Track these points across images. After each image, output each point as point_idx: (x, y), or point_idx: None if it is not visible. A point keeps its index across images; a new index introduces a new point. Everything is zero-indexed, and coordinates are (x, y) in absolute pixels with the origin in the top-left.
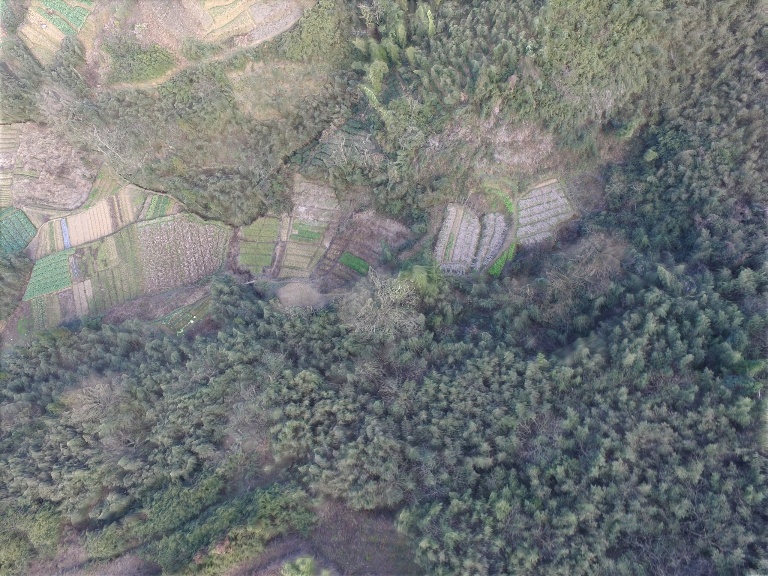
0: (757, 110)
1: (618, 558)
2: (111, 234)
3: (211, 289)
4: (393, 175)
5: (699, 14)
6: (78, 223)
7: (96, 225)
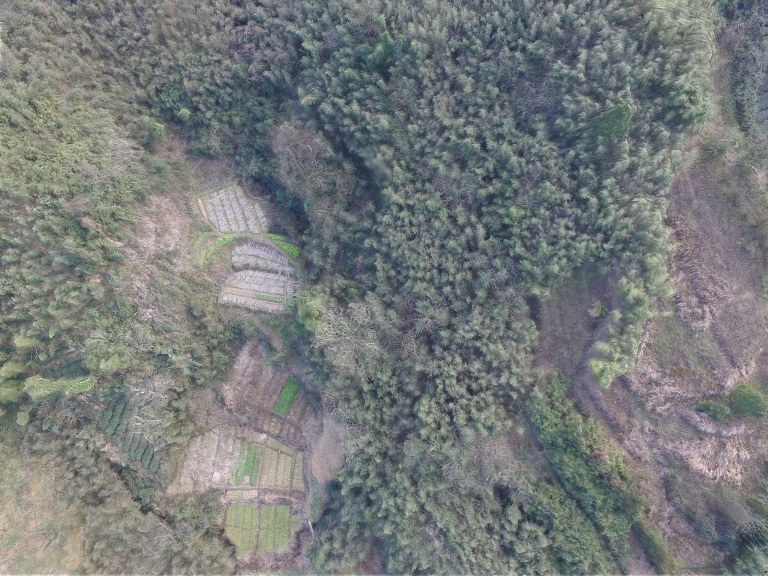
0: (152, 27)
1: (535, 129)
2: None
3: (327, 569)
4: (183, 361)
5: (39, 55)
6: None
7: None
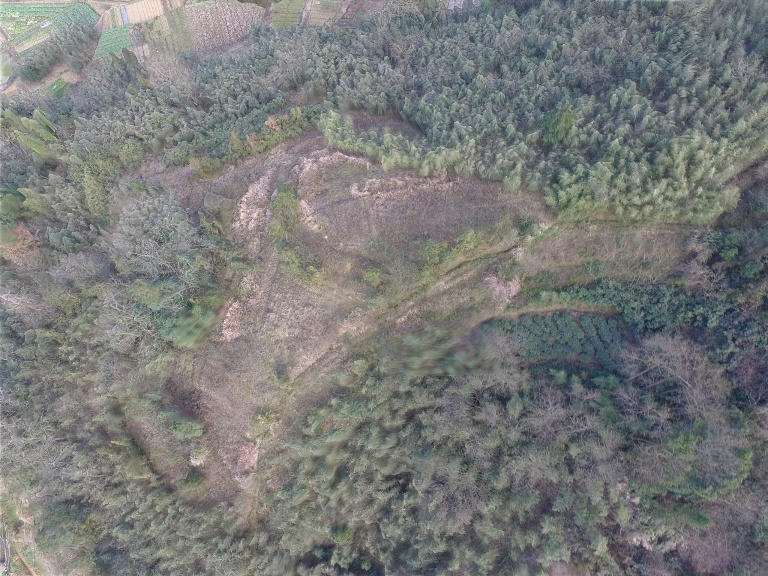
0: None
1: None
2: (163, 14)
3: (251, 27)
4: None
5: None
6: (135, 9)
7: (150, 10)
